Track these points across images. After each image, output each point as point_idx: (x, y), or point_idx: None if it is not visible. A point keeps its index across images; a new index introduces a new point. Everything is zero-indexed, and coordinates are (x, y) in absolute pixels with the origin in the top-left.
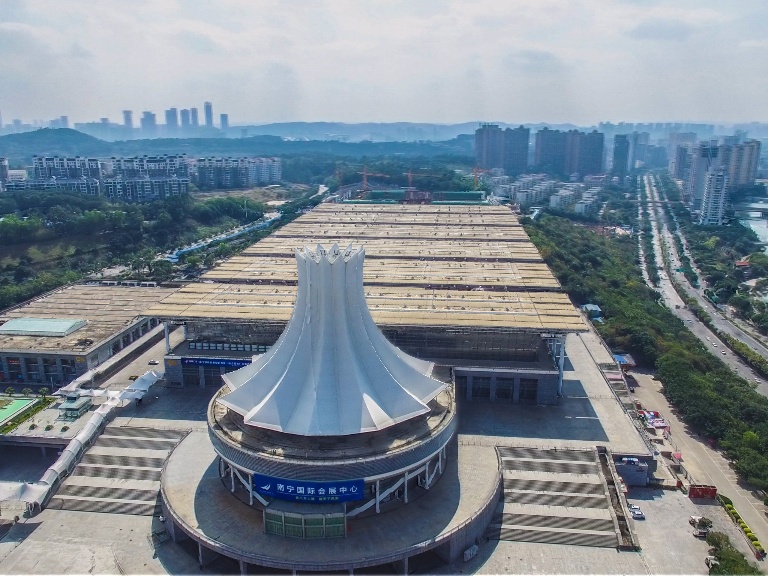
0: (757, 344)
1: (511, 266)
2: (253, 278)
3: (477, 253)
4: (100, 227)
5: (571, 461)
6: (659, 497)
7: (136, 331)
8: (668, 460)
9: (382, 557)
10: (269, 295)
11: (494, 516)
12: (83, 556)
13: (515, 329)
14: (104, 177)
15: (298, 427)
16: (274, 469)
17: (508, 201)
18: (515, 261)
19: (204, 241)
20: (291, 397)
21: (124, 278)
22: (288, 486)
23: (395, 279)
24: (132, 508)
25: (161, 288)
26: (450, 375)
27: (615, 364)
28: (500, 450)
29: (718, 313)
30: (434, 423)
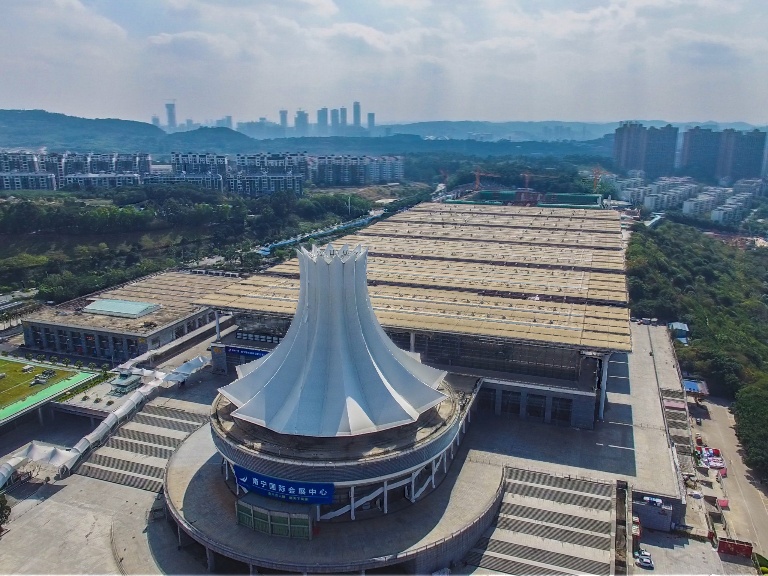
0: None
1: (583, 275)
2: None
3: (554, 260)
4: (208, 219)
5: (584, 493)
6: (681, 546)
7: (204, 318)
8: (710, 506)
9: (337, 565)
10: None
11: (480, 540)
12: (86, 521)
13: (548, 343)
14: (230, 173)
15: (278, 424)
16: (250, 462)
17: (628, 205)
18: (593, 270)
19: (302, 236)
20: (281, 394)
21: (217, 268)
22: (262, 481)
23: (451, 283)
24: (143, 483)
25: (241, 279)
26: (474, 386)
27: (681, 391)
28: (508, 471)
29: None
30: (422, 435)
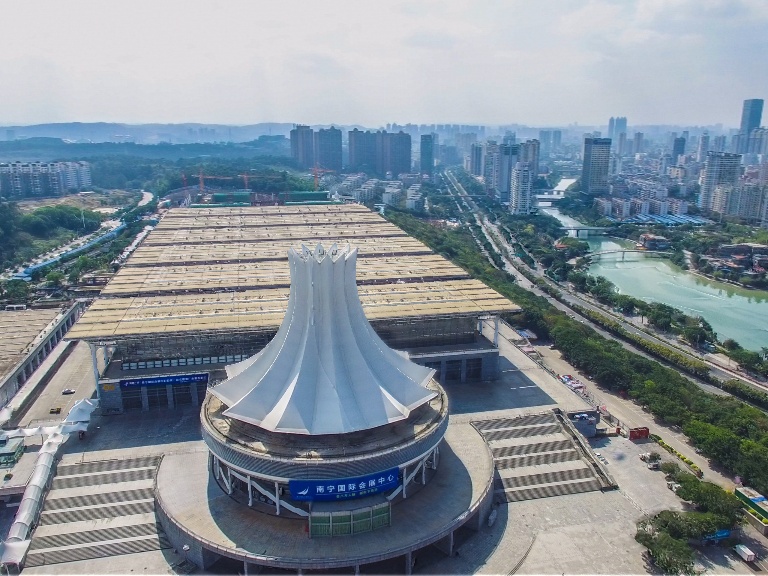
0: (602, 312)
1: (412, 259)
2: (164, 289)
3: (371, 249)
4: None
5: (536, 425)
6: (609, 444)
7: (33, 360)
8: None
9: (434, 535)
10: (198, 305)
11: (495, 483)
12: None
13: (461, 314)
14: None
15: (328, 427)
16: (313, 472)
17: (351, 200)
18: (410, 254)
19: (46, 256)
20: (307, 399)
21: None
22: (328, 486)
23: None
24: (133, 546)
25: (35, 310)
26: None
27: (524, 339)
28: (475, 425)
29: (562, 289)
30: (438, 406)
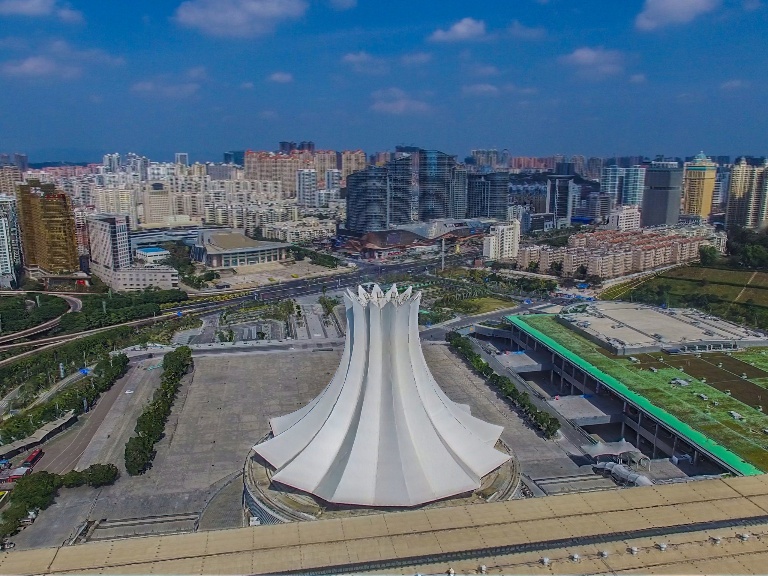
0: None
1: None
2: None
3: None
4: None
5: None
6: None
7: None
8: None
9: None
10: None
11: None
12: None
13: None
14: None
15: None
16: None
17: None
18: None
19: None
20: None
21: None
22: None
23: None
24: None
25: None
26: None
27: None
28: None
29: None
30: None
